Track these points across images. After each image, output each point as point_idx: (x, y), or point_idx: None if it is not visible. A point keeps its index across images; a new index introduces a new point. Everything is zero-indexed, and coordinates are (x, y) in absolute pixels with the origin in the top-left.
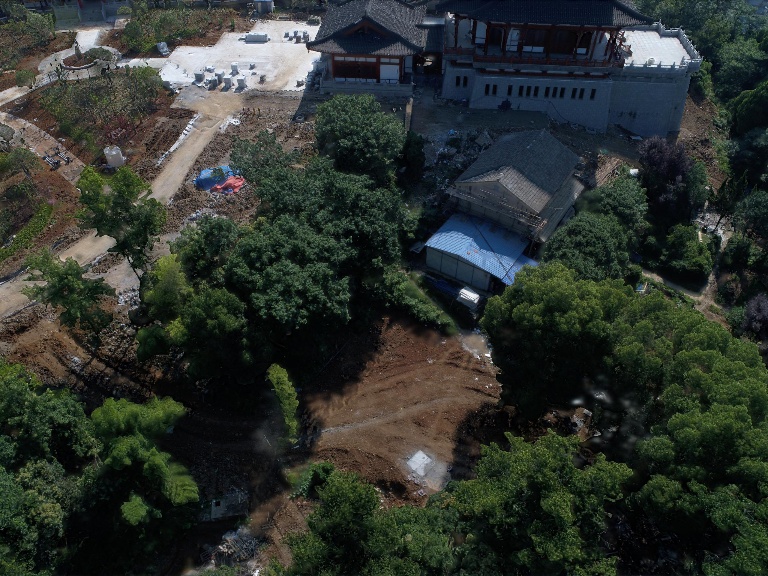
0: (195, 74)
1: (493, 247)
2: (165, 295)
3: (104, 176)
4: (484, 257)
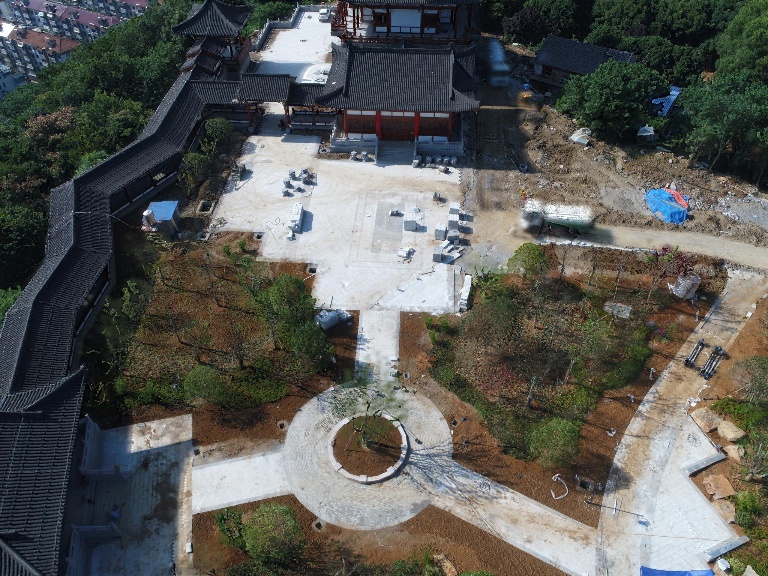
0: None
1: None
2: None
3: (711, 300)
4: None
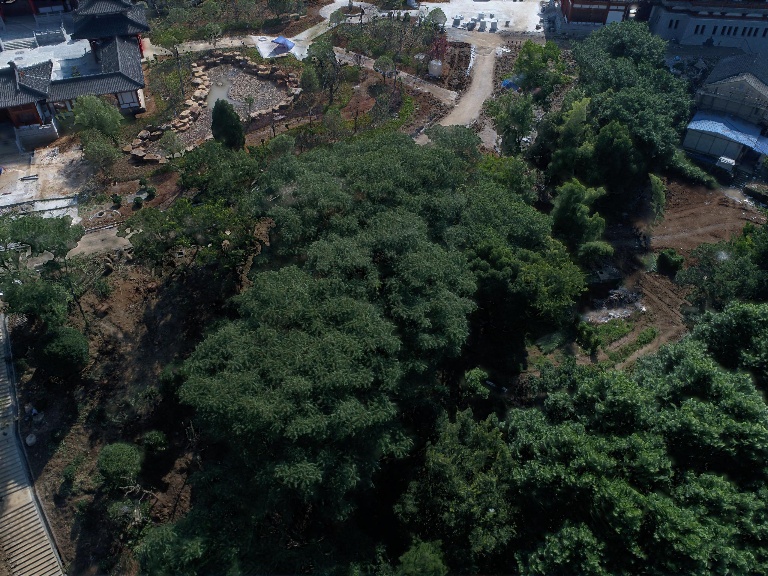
0: (454, 19)
1: (739, 129)
2: (576, 127)
3: (431, 82)
4: (736, 135)
